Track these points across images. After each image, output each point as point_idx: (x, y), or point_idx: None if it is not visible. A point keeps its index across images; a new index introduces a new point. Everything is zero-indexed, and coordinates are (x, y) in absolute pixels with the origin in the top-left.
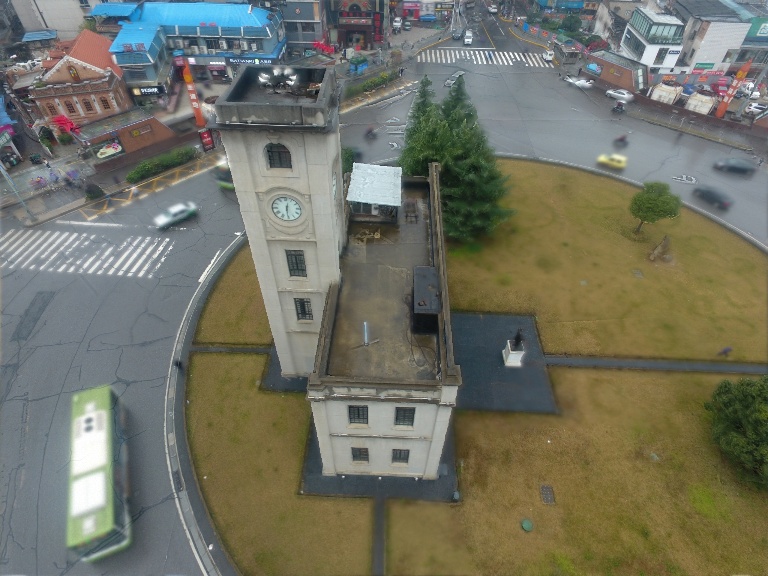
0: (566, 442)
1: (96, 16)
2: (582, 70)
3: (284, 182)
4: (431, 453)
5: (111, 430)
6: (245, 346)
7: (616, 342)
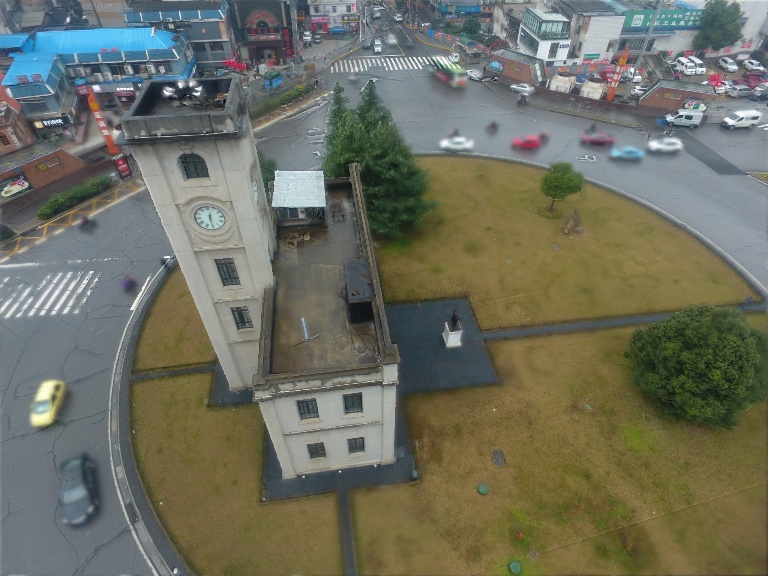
0: (510, 408)
1: None
2: (486, 68)
3: (203, 191)
4: (384, 436)
5: (52, 474)
6: (188, 367)
7: (544, 311)
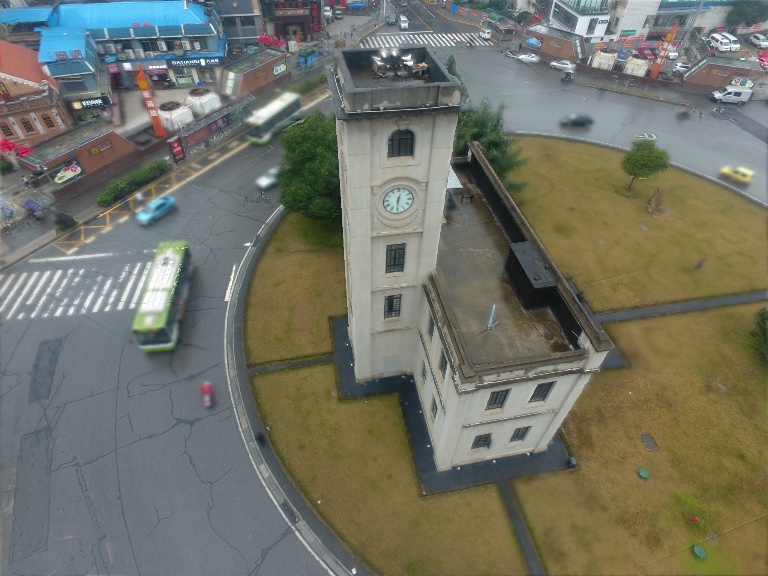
0: (645, 390)
1: (5, 23)
2: (522, 45)
3: (402, 171)
4: (552, 424)
5: (193, 476)
6: (305, 359)
7: (650, 291)
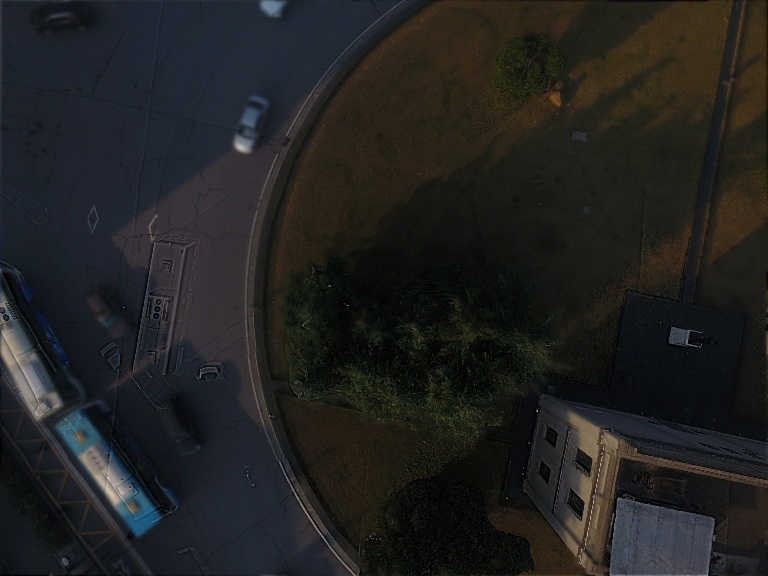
0: None
1: None
2: None
3: None
4: None
5: None
6: None
7: (674, 218)
